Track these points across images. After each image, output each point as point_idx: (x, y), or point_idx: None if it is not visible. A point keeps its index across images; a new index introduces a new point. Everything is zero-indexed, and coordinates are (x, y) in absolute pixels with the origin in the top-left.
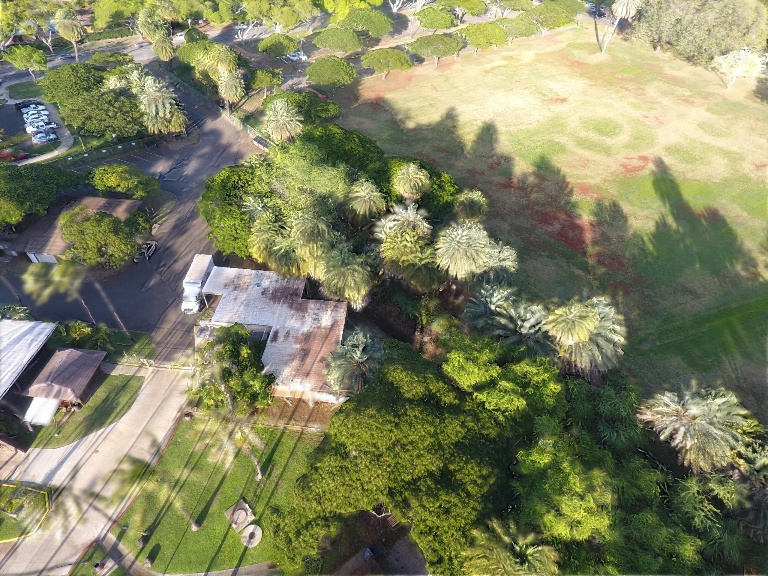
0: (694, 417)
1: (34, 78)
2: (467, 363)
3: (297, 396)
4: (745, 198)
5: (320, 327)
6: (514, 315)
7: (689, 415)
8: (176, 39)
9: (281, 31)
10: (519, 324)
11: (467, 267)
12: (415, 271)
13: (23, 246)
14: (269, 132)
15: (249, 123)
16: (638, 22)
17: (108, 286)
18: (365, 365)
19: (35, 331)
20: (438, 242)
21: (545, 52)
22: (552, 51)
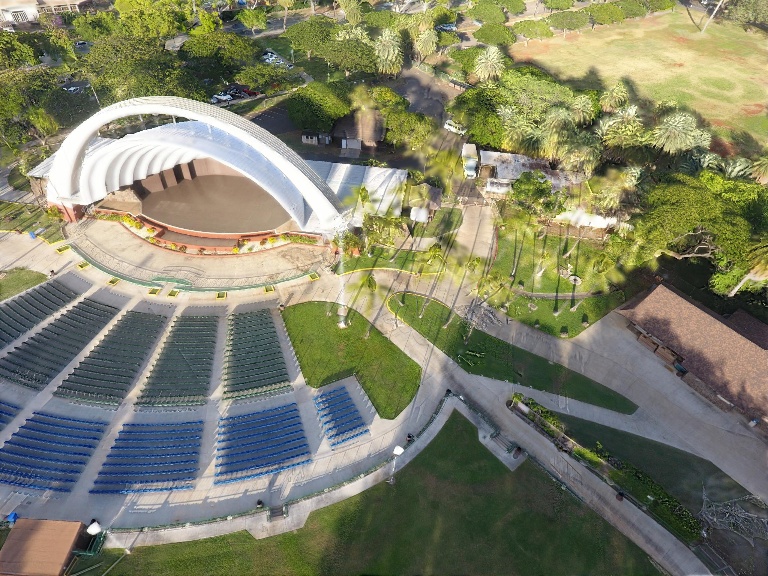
0: None
1: (254, 36)
2: (717, 176)
3: (567, 222)
4: None
5: (573, 184)
6: (723, 167)
7: None
8: (341, 12)
9: None
10: (730, 171)
11: (678, 145)
12: (635, 151)
13: (343, 134)
14: (478, 72)
15: (437, 72)
16: (735, 6)
17: (402, 163)
18: (638, 186)
19: (397, 173)
20: (655, 130)
21: (652, 30)
22: (658, 30)
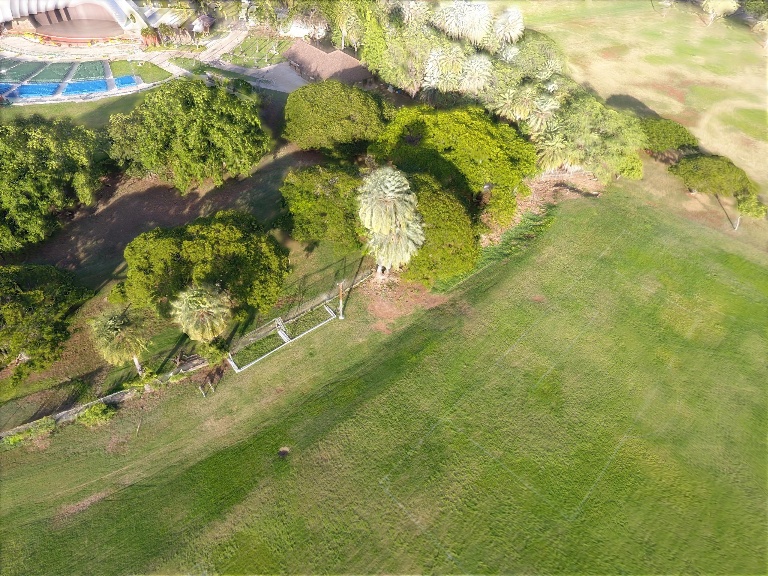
0: (412, 8)
1: None
2: None
3: (288, 36)
4: (502, 3)
5: None
6: None
7: (411, 8)
8: None
9: None
10: None
11: None
12: None
13: None
14: None
15: None
16: None
17: None
18: None
19: (189, 10)
20: None
21: None
22: None
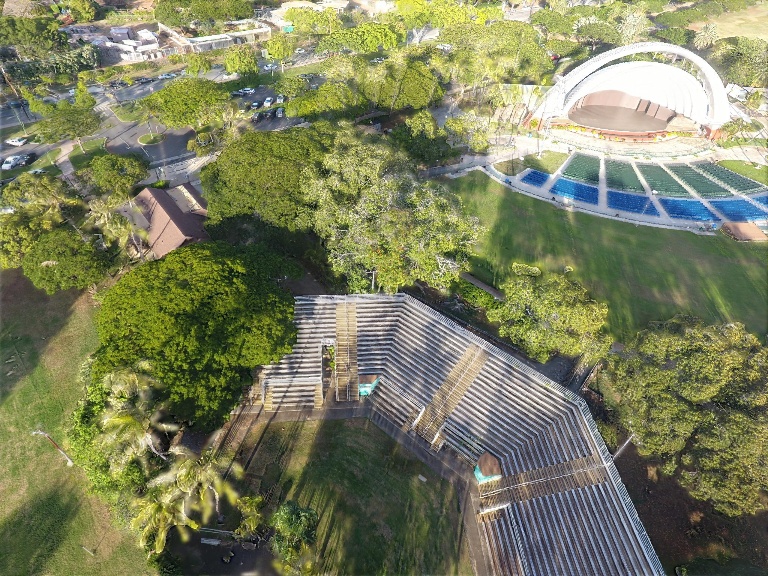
0: None
1: None
2: None
3: None
4: None
5: None
6: None
7: None
8: (523, 9)
9: (587, 4)
10: None
11: None
12: None
13: None
14: (697, 42)
15: None
16: None
17: None
18: None
19: None
20: None
21: (760, 16)
22: (764, 16)
